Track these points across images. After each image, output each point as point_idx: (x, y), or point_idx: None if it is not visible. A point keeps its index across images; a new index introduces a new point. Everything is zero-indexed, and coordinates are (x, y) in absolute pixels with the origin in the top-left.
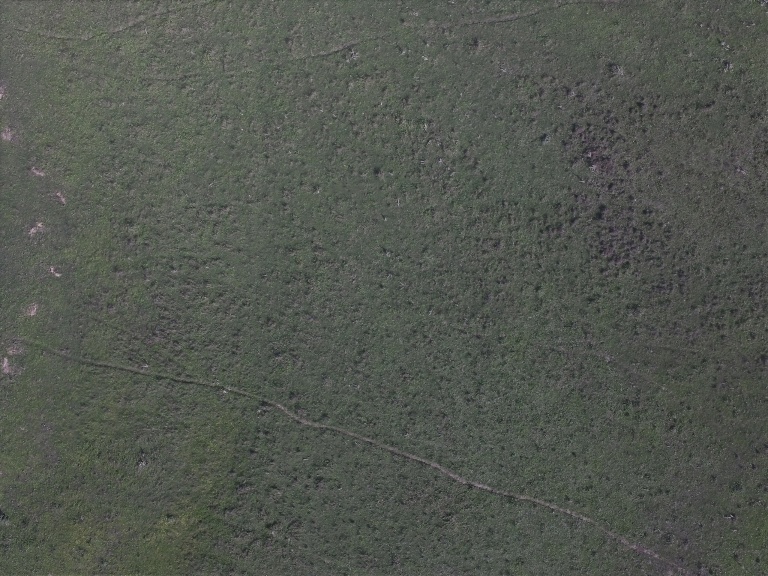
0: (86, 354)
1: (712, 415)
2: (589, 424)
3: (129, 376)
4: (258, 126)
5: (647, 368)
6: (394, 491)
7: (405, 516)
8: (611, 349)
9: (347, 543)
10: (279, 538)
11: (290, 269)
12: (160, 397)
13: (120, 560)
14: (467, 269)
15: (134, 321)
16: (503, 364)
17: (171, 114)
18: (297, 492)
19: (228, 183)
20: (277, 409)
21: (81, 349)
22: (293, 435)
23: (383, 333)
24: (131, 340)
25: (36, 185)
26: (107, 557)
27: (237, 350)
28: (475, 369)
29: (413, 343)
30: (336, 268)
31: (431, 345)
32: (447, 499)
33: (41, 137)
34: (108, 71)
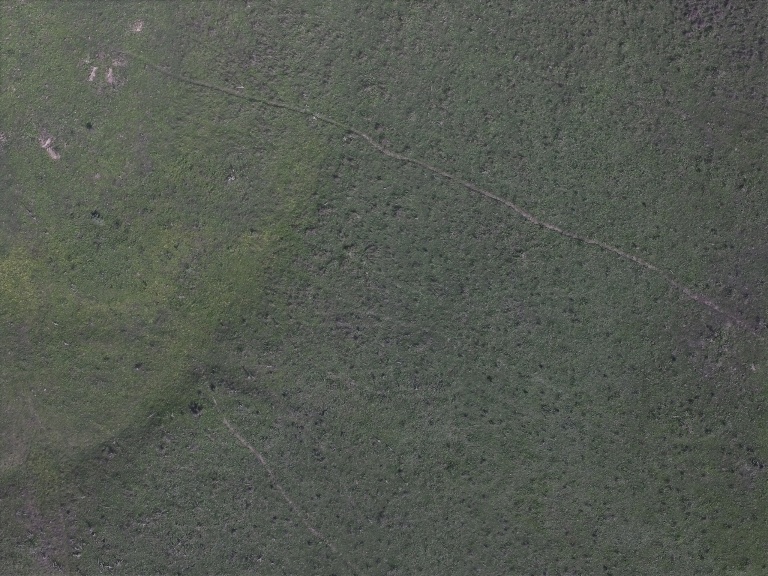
0: (185, 72)
1: None
2: (661, 177)
3: (224, 96)
4: None
5: (721, 129)
6: (468, 225)
7: (477, 250)
8: (688, 108)
9: (419, 271)
10: (355, 260)
11: (384, 6)
12: (252, 118)
13: (204, 268)
14: (554, 20)
15: (233, 45)
16: (582, 113)
17: None
18: (375, 218)
19: None
20: (362, 138)
21: (181, 67)
22: (376, 164)
23: (469, 75)
24: (229, 62)
25: None
26: (192, 264)
27: (328, 79)
28: (555, 115)
29: (497, 86)
30: (428, 9)
31: (514, 89)
32: (518, 237)
33: None
34: None
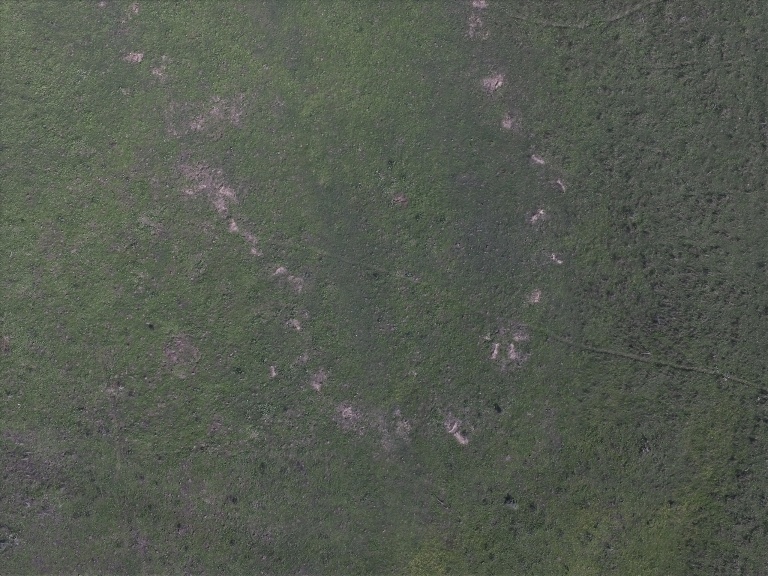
0: (587, 341)
1: None
2: None
3: (629, 363)
4: (755, 115)
5: None
6: None
7: None
8: None
9: None
10: None
11: None
12: (660, 384)
13: (624, 545)
14: None
15: (633, 308)
16: None
17: (669, 102)
18: None
19: (726, 172)
20: None
21: (583, 336)
22: None
23: None
24: (631, 327)
25: (536, 172)
26: (611, 542)
27: (737, 338)
28: None
29: None
30: None
31: None
32: None
33: (540, 125)
34: (606, 59)
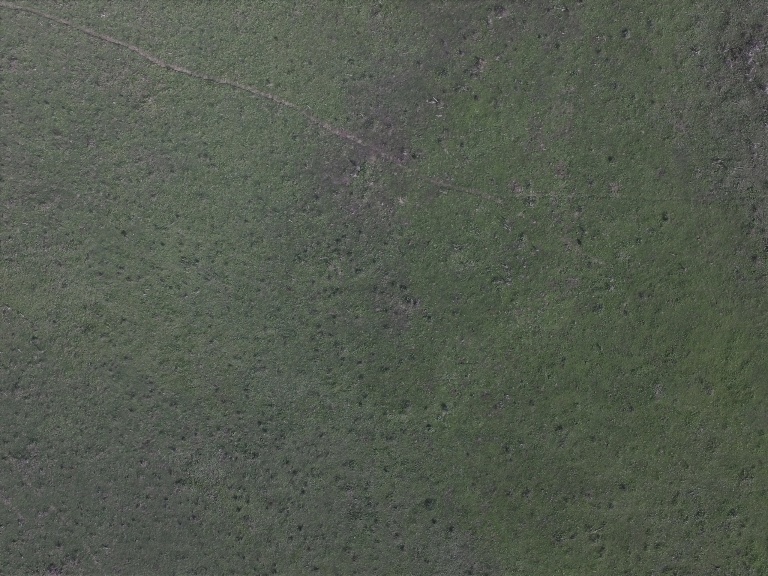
0: None
1: (420, 2)
2: (292, 8)
3: None
4: None
5: None
6: (90, 73)
7: (101, 98)
8: None
9: (42, 125)
10: None
11: None
12: None
13: None
14: None
15: None
16: None
17: None
18: None
19: None
20: None
21: None
22: None
23: None
24: None
25: None
26: None
27: None
28: None
29: None
30: None
31: None
32: (144, 81)
33: None
34: None
